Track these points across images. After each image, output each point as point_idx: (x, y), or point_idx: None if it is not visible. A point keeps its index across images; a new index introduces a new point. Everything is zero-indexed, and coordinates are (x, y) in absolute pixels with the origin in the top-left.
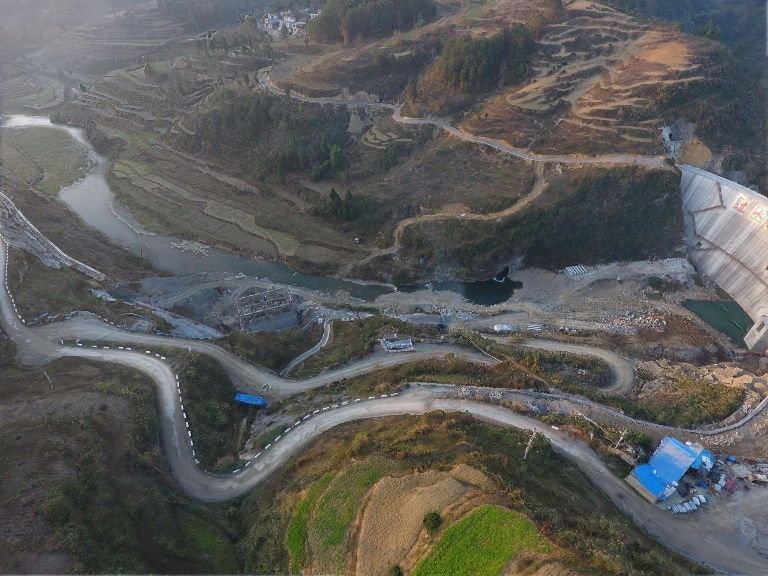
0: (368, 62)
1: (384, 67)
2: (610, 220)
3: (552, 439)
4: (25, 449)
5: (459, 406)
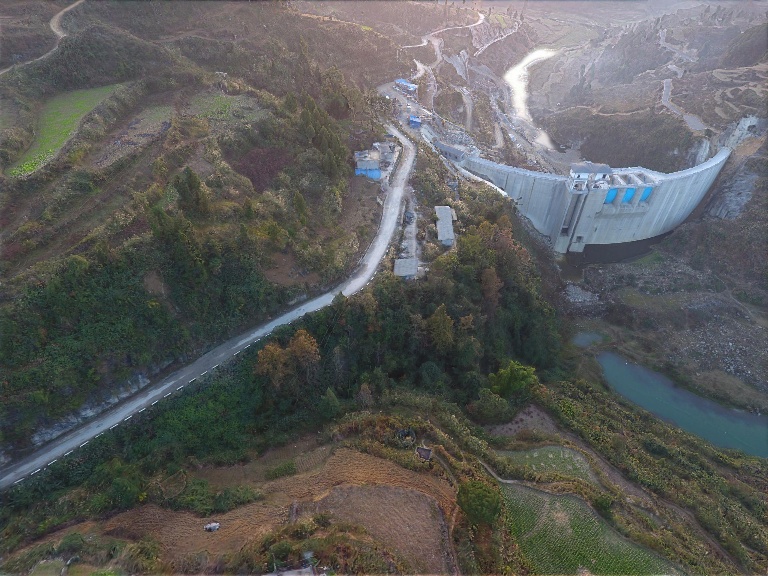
0: (723, 31)
1: (729, 38)
2: (634, 147)
3: None
4: None
5: (422, 70)
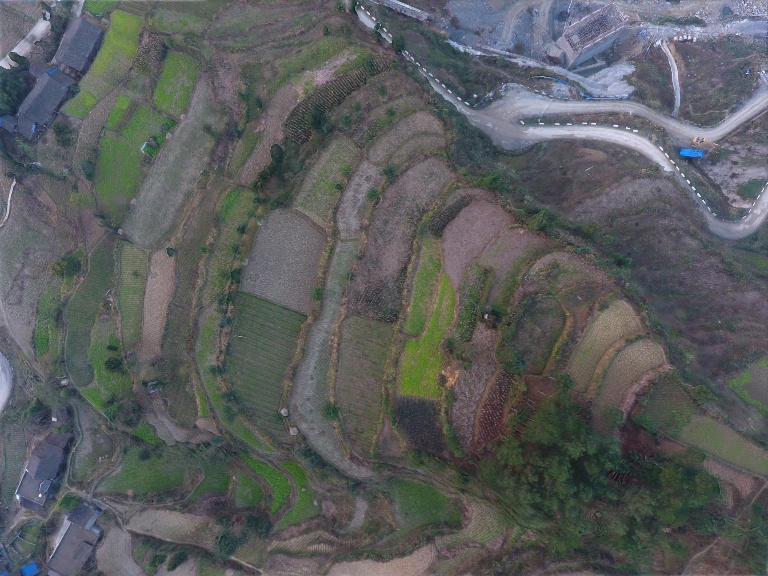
0: None
1: None
2: None
3: None
4: (651, 232)
5: None
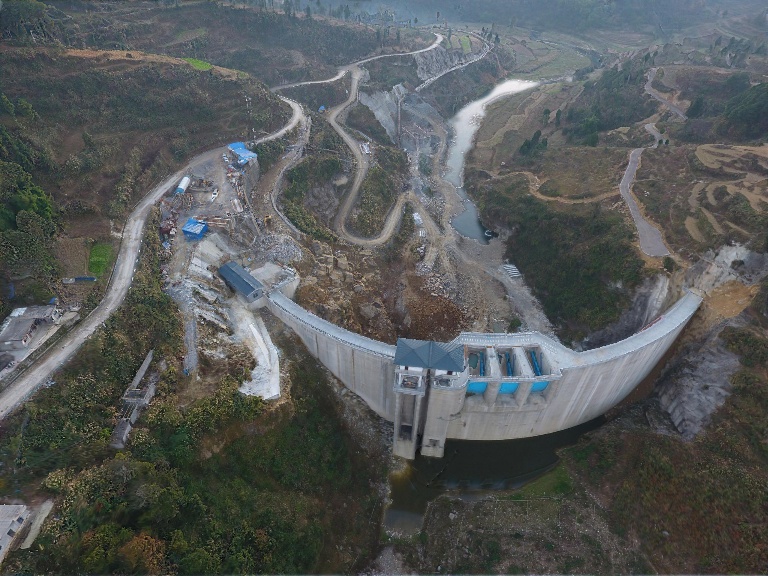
0: None
1: None
2: (567, 260)
3: (268, 138)
4: None
5: None
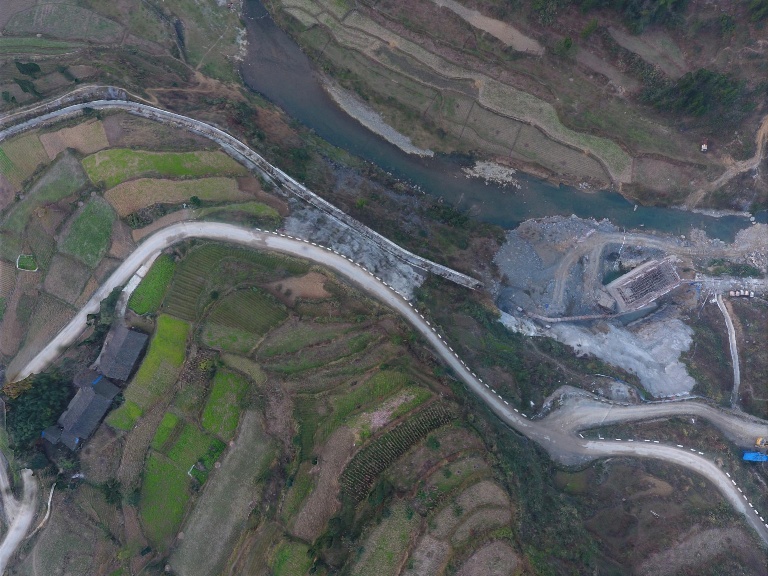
0: None
1: None
2: None
3: None
4: None
5: None
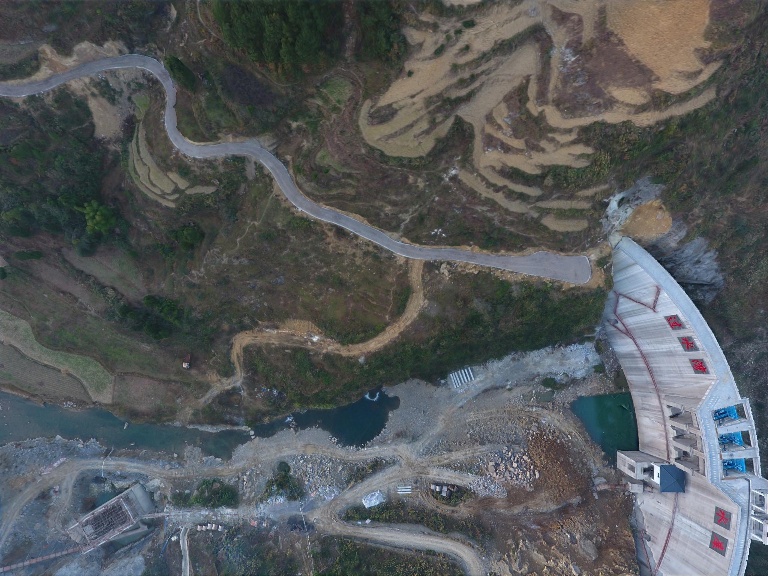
0: None
1: None
2: None
3: None
4: None
5: None
